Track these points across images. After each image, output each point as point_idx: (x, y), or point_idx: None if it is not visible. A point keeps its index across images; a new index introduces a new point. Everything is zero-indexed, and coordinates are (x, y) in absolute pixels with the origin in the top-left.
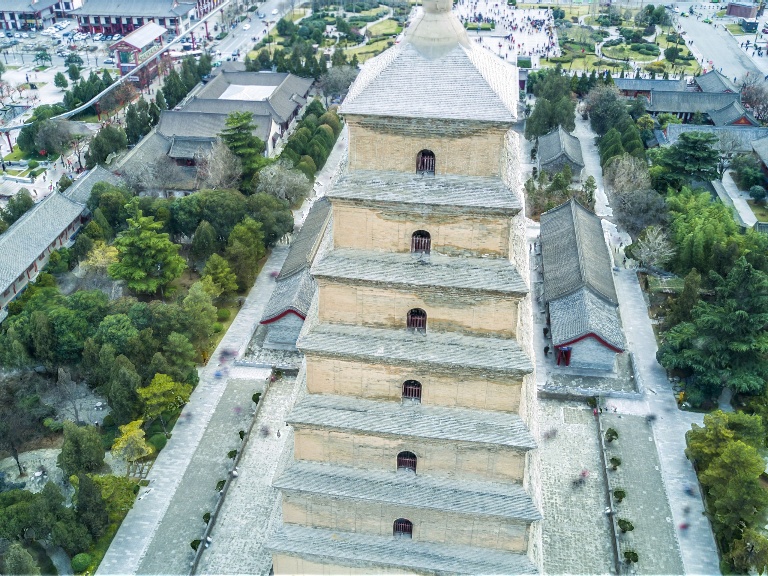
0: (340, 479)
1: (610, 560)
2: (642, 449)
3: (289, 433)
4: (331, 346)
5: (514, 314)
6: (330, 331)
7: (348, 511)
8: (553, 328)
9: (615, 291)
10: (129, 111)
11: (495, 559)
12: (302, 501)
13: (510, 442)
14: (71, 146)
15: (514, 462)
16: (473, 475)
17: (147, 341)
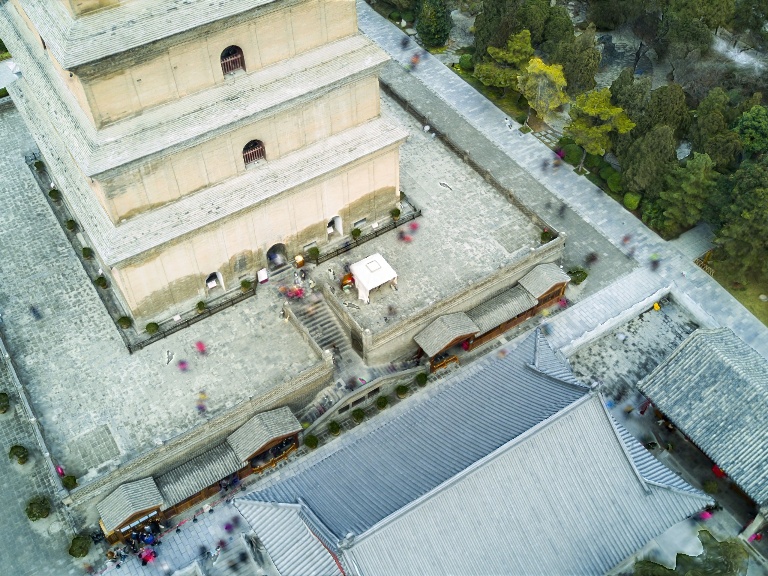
0: None
1: None
2: None
3: None
4: None
5: None
6: None
7: None
8: None
9: None
10: None
11: None
12: None
13: None
14: None
15: None
16: None
17: None
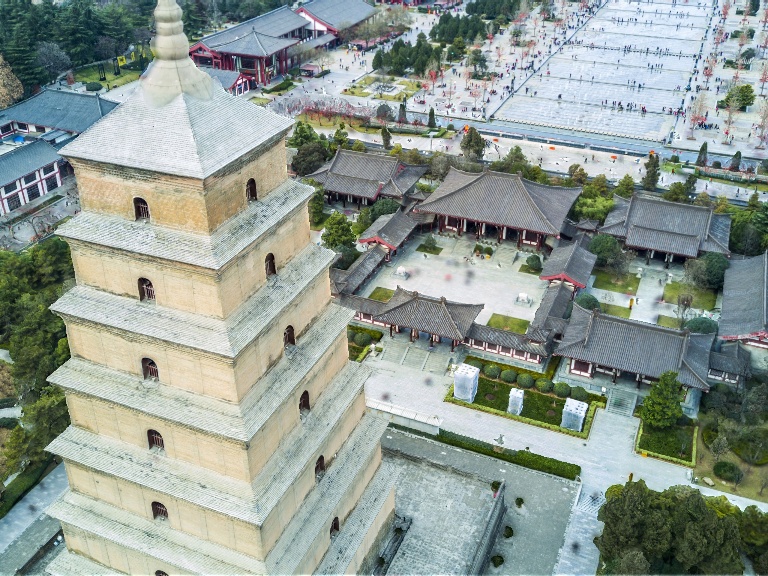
0: None
1: None
2: None
3: (363, 462)
4: None
5: None
6: None
7: None
8: None
9: None
10: None
11: None
12: None
13: None
14: None
15: None
16: None
17: None
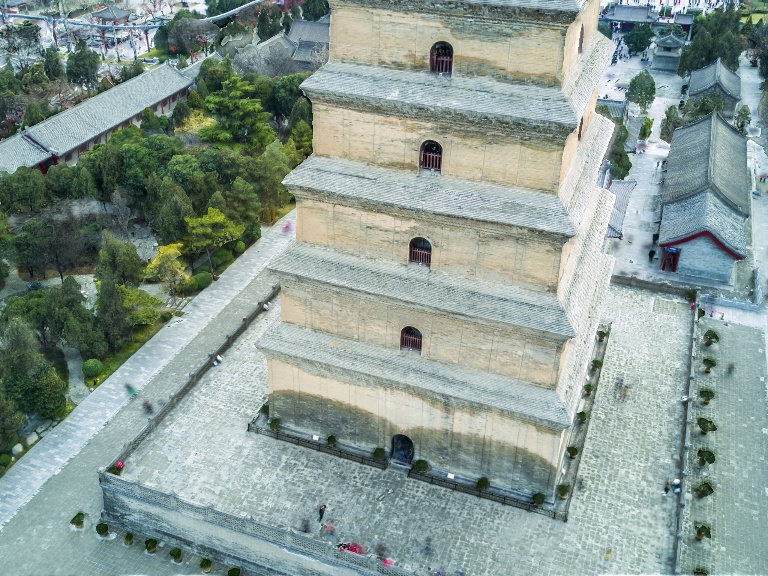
0: (343, 267)
1: (675, 447)
2: (747, 358)
3: None
4: (339, 86)
5: (560, 50)
6: (341, 71)
7: (351, 312)
8: (662, 228)
9: (748, 203)
10: (261, 15)
11: (516, 391)
12: (301, 294)
13: (541, 226)
14: (199, 41)
15: (547, 260)
16: (497, 276)
17: (210, 182)
